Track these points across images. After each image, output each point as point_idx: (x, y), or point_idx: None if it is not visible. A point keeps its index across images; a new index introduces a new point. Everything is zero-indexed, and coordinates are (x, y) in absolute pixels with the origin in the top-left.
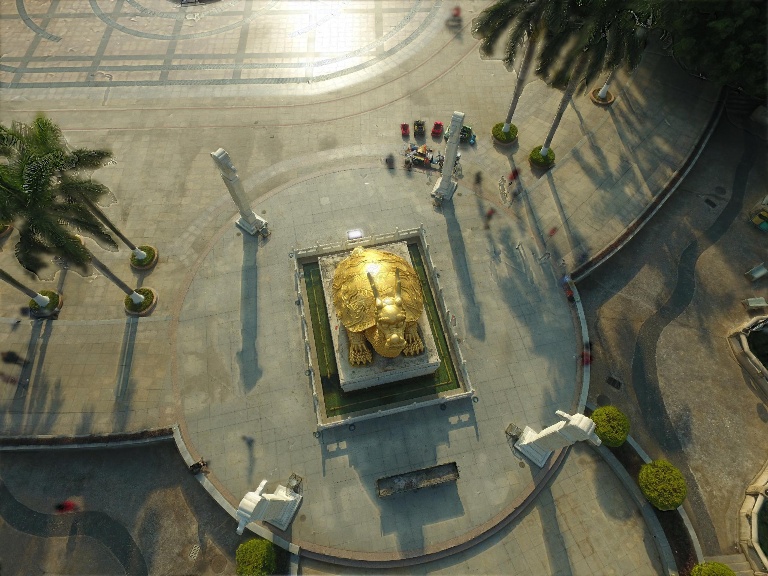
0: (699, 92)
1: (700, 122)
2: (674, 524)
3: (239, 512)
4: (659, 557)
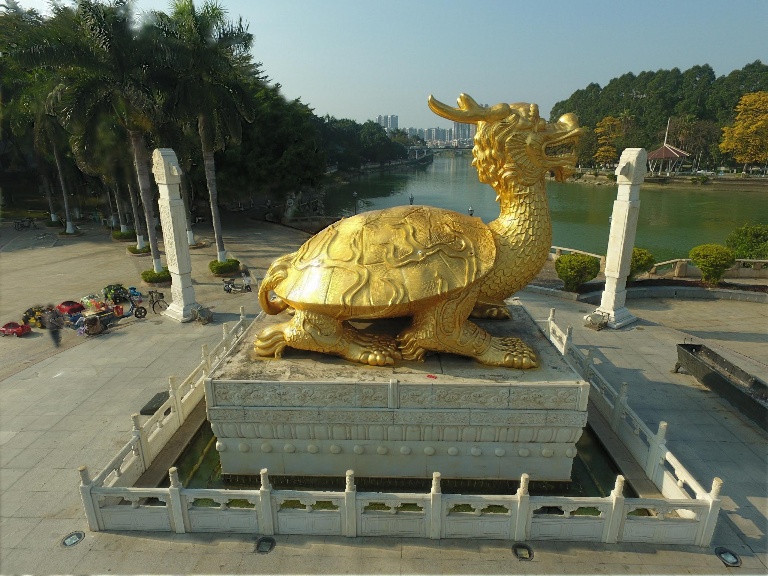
0: (244, 225)
1: (273, 228)
2: (659, 281)
3: None
4: (694, 298)
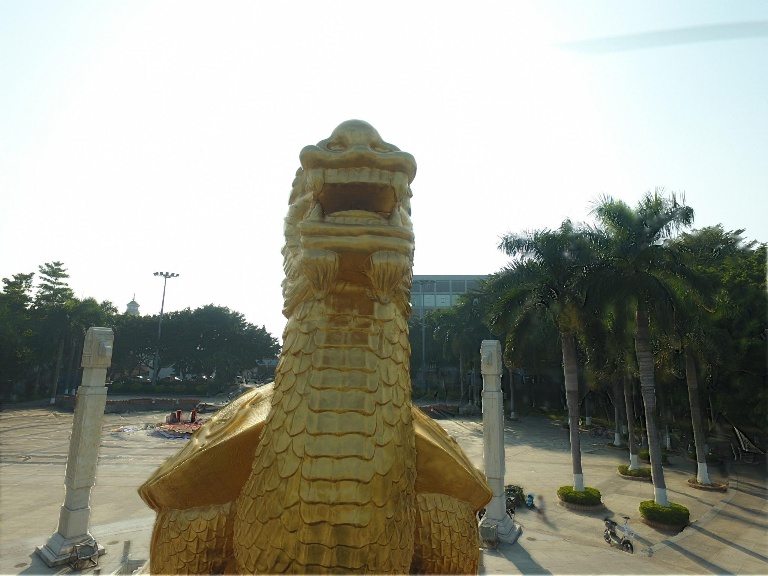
0: None
1: None
2: None
3: None
4: None
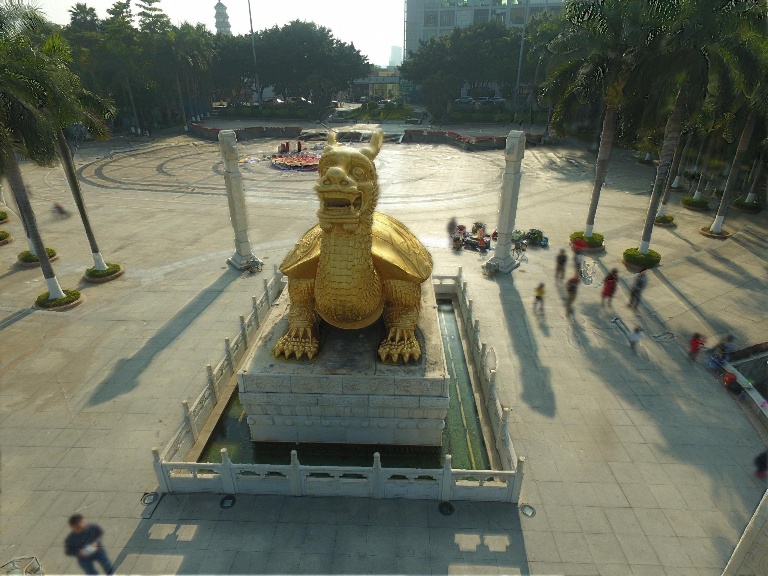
0: None
1: None
2: None
3: None
4: None
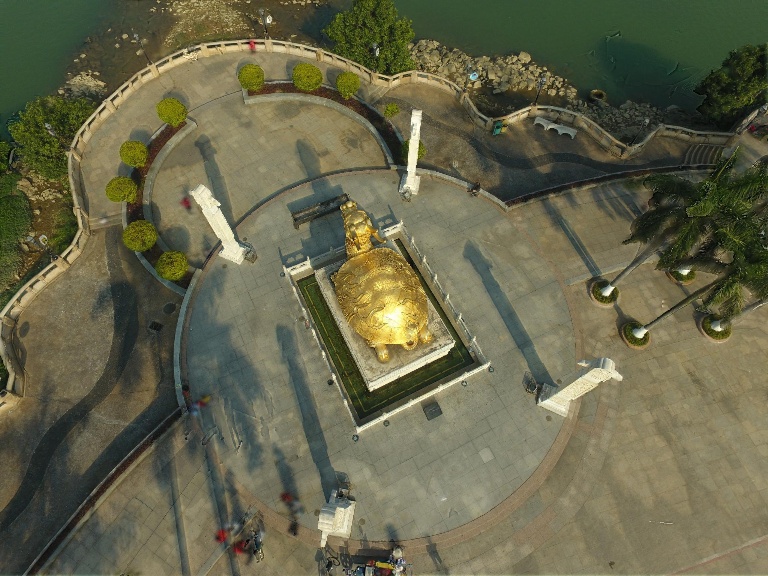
0: None
1: None
2: None
3: None
4: (153, 213)
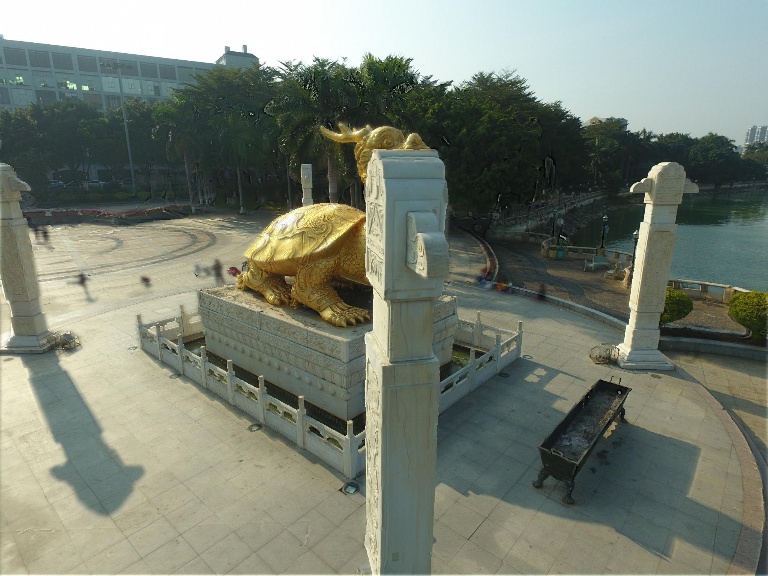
0: None
1: (464, 236)
2: None
3: (392, 159)
4: None
